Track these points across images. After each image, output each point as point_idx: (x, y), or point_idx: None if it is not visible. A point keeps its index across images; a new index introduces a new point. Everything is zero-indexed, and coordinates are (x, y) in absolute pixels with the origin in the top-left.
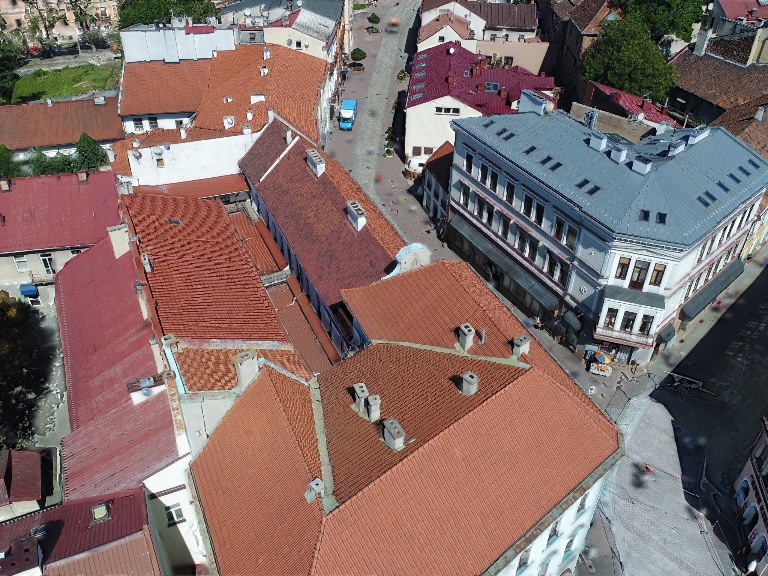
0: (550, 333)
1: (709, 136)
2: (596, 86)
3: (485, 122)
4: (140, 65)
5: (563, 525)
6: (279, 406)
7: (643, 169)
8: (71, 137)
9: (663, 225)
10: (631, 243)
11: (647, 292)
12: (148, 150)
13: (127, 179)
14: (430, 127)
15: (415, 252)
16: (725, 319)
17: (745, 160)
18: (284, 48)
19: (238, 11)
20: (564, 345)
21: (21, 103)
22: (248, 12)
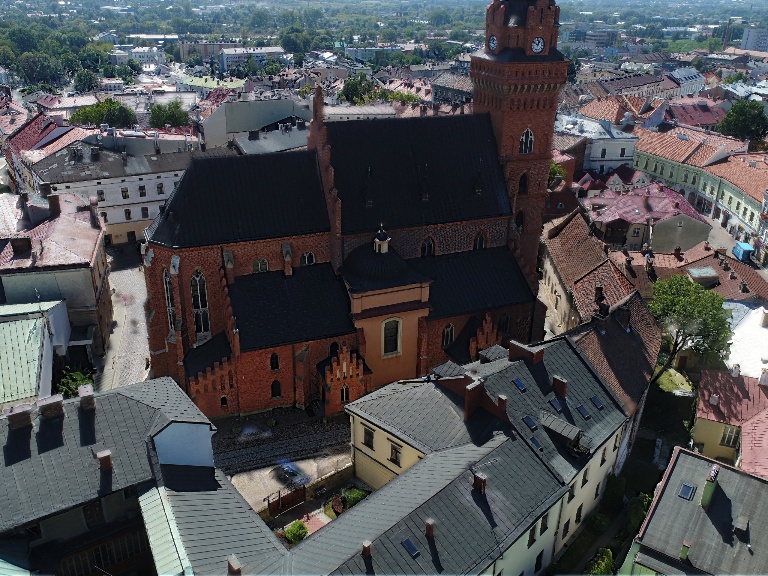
0: None
1: None
2: None
3: None
4: None
5: None
6: None
7: None
8: None
9: None
10: None
11: None
12: None
13: None
14: None
15: None
16: None
17: None
18: None
19: None
20: None
21: None
22: None
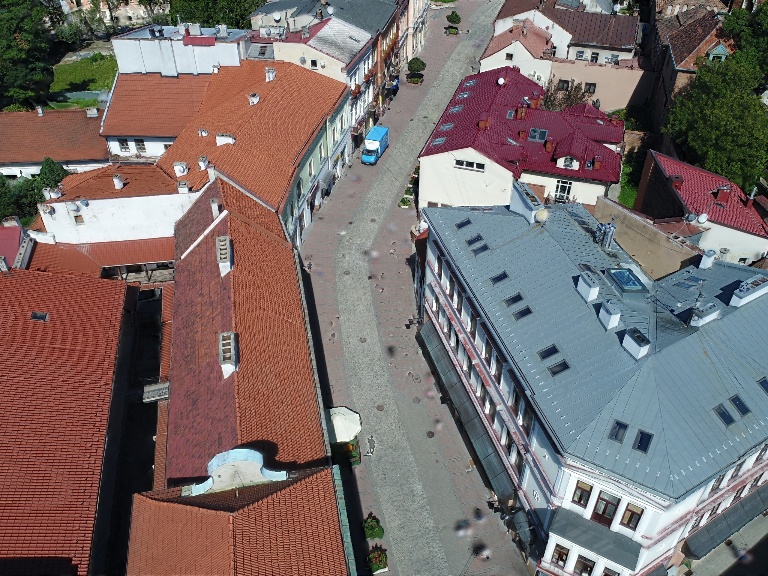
0: (504, 521)
1: None
2: (656, 160)
3: (460, 220)
4: (134, 77)
5: None
6: None
7: (635, 351)
8: (52, 154)
9: (642, 454)
10: (591, 469)
11: (617, 532)
12: (62, 205)
13: (40, 236)
14: (448, 181)
15: (233, 464)
16: (766, 545)
17: None
18: (296, 67)
19: (267, 14)
20: (517, 546)
21: (64, 92)
22: (277, 16)
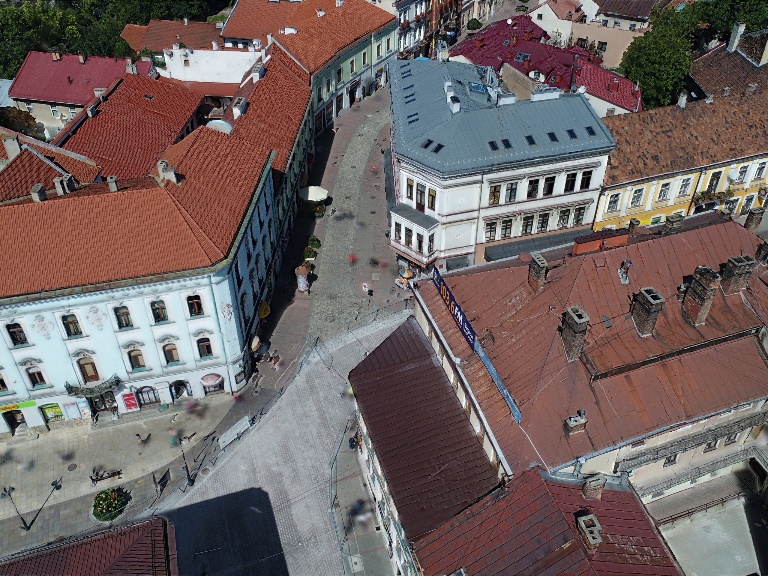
0: None
1: (561, 99)
2: (574, 60)
3: (404, 64)
4: (251, 0)
5: (171, 313)
6: (5, 167)
7: (452, 108)
8: None
9: (435, 154)
10: (410, 165)
11: (428, 215)
12: (178, 51)
13: (162, 71)
14: None
15: (216, 126)
16: None
17: (584, 126)
18: (361, 0)
19: None
20: None
21: None
22: None
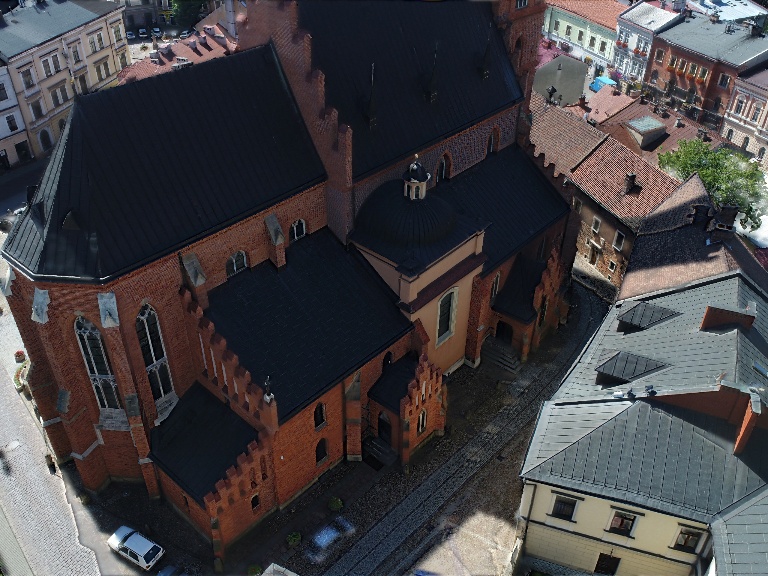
0: None
1: None
2: None
3: None
4: None
5: None
6: None
7: None
8: None
9: None
10: None
11: None
12: None
13: None
14: None
15: None
16: None
17: None
18: None
19: None
20: None
21: None
22: None
